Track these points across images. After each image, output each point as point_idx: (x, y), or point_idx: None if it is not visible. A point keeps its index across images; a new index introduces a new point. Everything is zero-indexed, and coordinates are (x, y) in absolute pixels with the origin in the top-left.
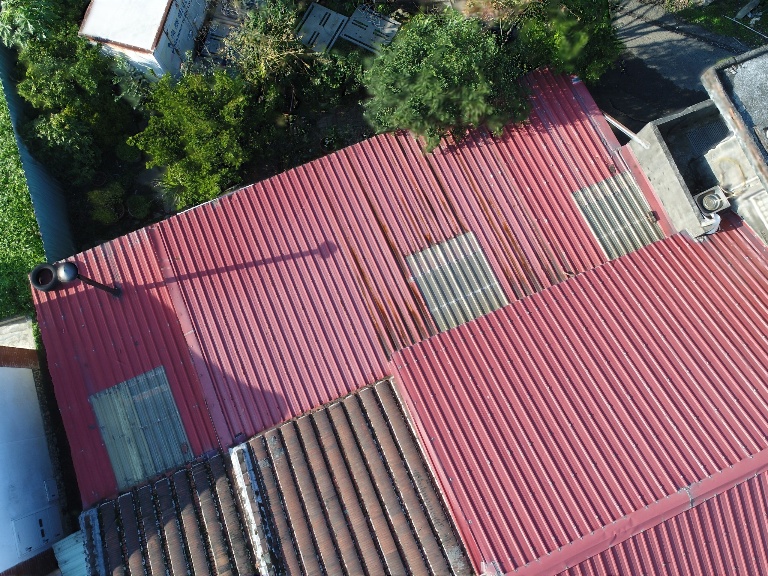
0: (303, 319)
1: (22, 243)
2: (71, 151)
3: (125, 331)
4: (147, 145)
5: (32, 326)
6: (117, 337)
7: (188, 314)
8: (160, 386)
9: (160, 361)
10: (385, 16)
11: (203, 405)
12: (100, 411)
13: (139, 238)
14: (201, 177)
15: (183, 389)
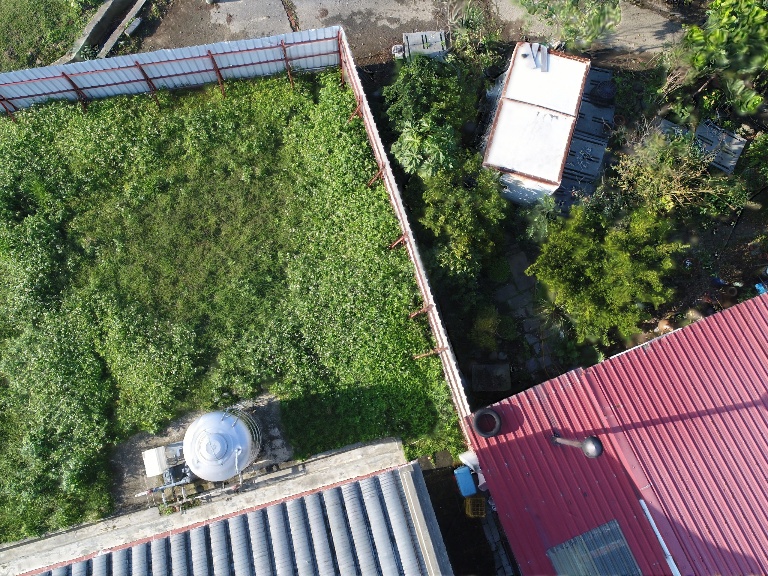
0: (759, 475)
1: (399, 365)
2: (460, 277)
3: (571, 481)
4: (545, 276)
5: (403, 448)
6: (564, 487)
7: (641, 467)
8: (616, 541)
9: (613, 514)
10: (730, 132)
11: (663, 563)
12: (560, 567)
13: (570, 381)
14: (612, 314)
15: (640, 545)
